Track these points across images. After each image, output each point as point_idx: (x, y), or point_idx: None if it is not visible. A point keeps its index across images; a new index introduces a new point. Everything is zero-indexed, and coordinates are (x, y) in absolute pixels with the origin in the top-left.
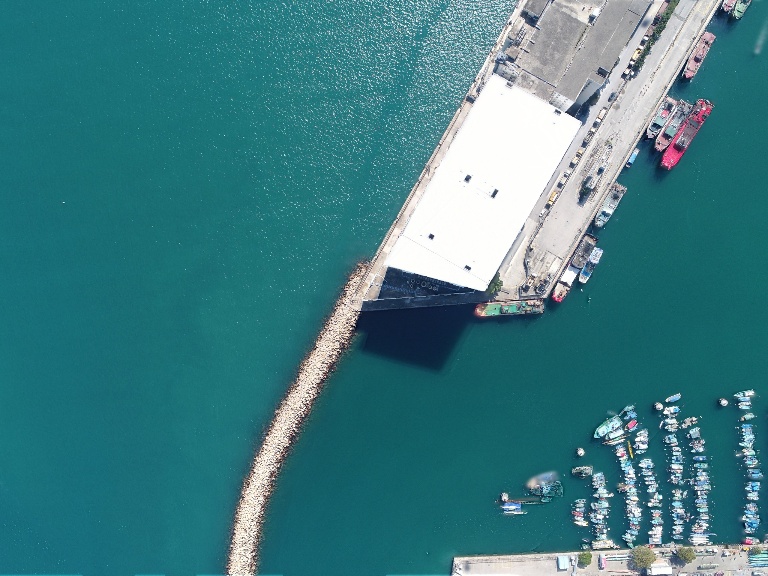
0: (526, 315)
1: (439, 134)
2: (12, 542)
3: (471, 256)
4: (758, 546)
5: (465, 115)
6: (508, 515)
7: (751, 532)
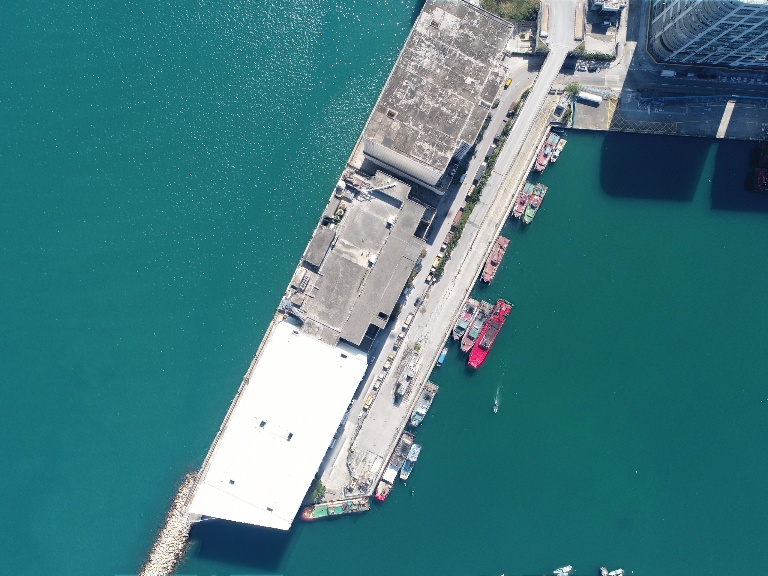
0: (354, 512)
1: (255, 346)
2: None
3: (272, 497)
4: None
5: None
6: None
7: None
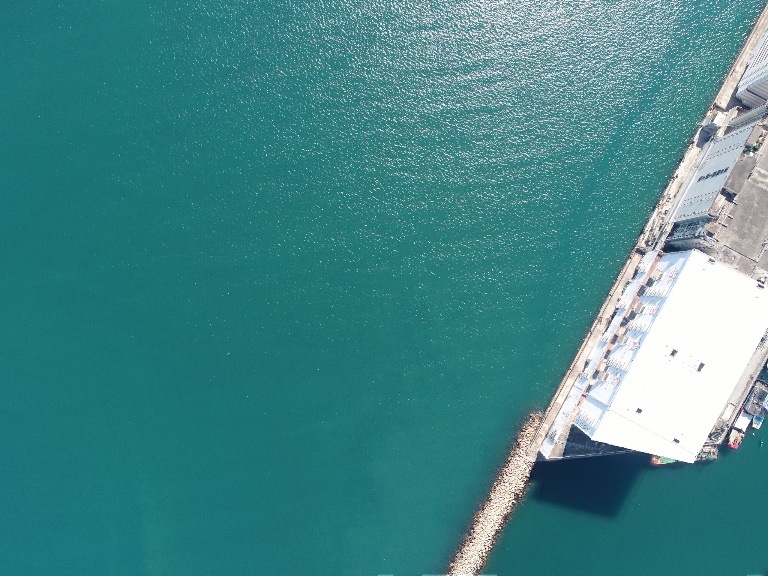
0: (700, 461)
1: (609, 285)
2: None
3: (678, 429)
4: None
5: (635, 266)
6: None
7: None
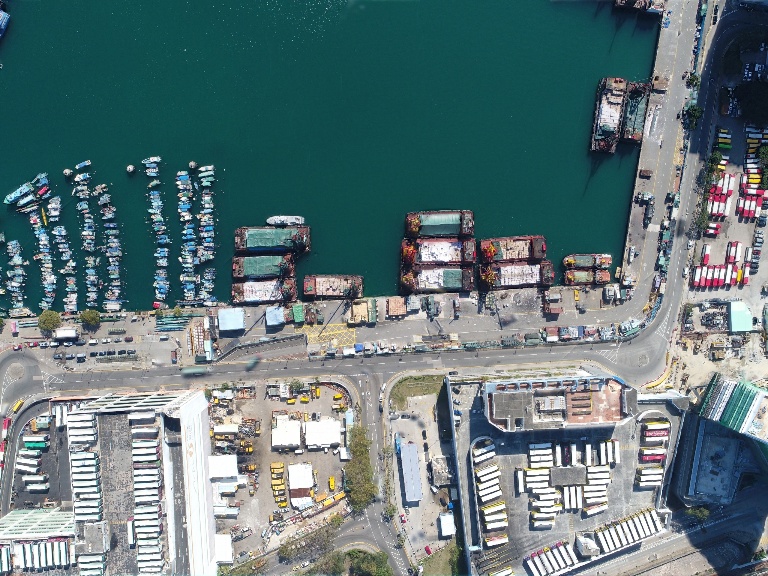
0: None
1: None
2: None
3: None
4: (166, 311)
5: None
6: None
7: (162, 298)
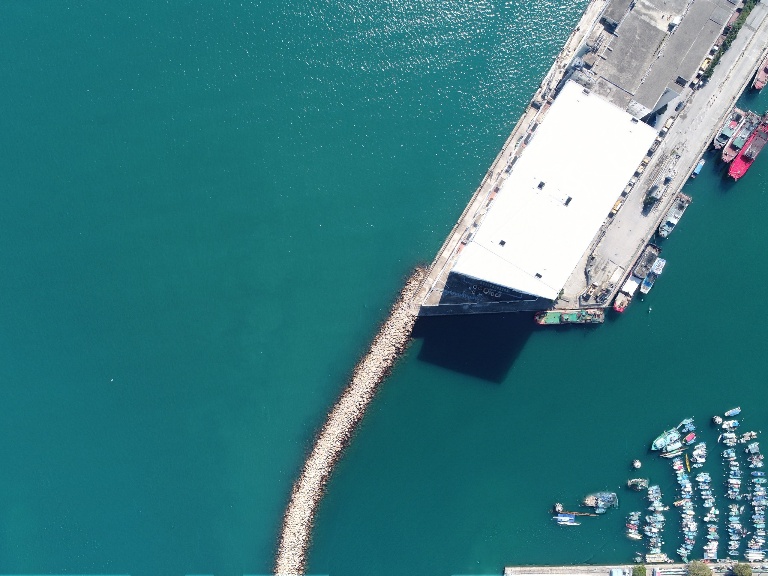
0: (585, 324)
1: (502, 139)
2: (61, 540)
3: (542, 264)
4: None
5: (529, 121)
6: (561, 526)
7: None
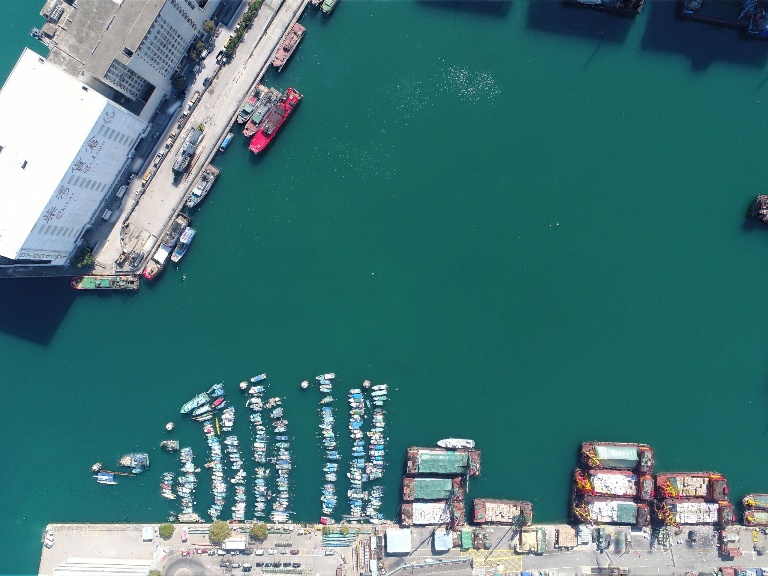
0: (124, 290)
1: None
2: None
3: (2, 224)
4: (332, 526)
5: None
6: (102, 485)
7: (328, 512)
